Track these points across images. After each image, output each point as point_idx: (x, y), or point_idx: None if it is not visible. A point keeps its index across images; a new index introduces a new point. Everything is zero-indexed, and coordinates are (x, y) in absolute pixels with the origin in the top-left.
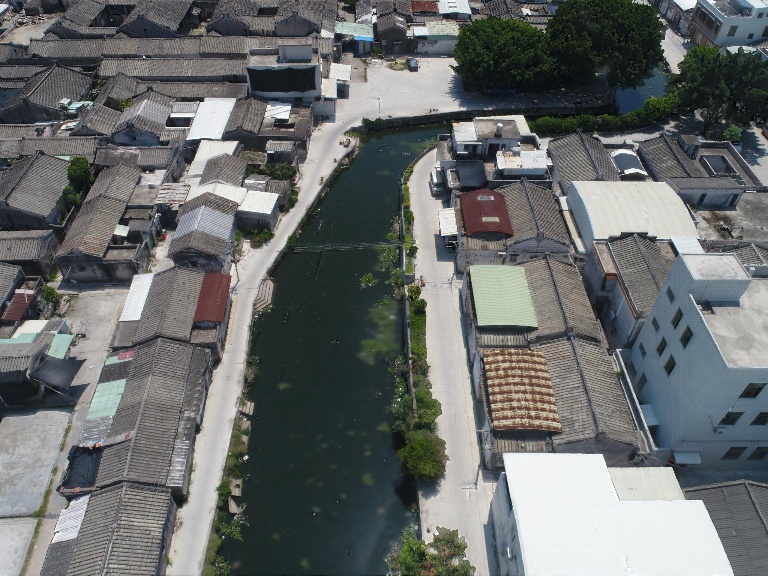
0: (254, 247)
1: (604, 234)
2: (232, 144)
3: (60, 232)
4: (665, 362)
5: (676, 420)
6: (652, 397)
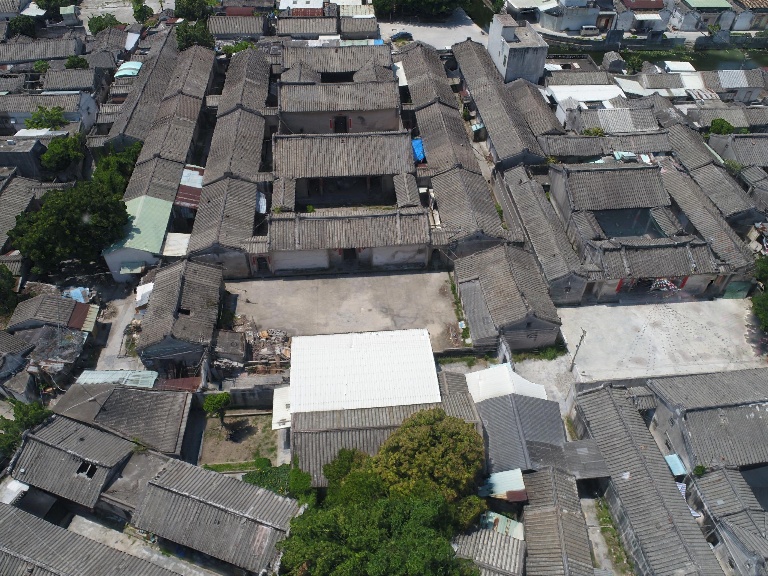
0: None
1: None
2: (619, 80)
3: None
4: None
5: None
6: None
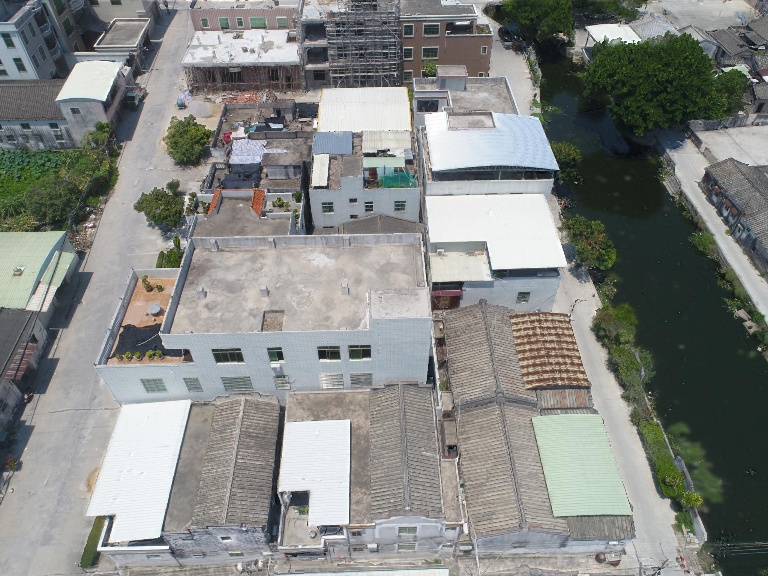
0: None
1: None
2: None
3: None
4: None
5: None
6: None
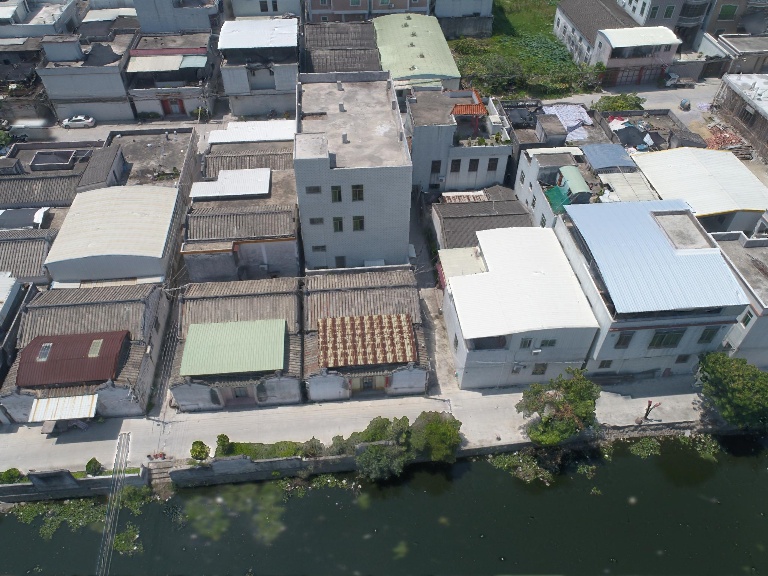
0: None
1: (156, 249)
2: None
3: None
4: (352, 227)
5: (397, 239)
6: (361, 257)
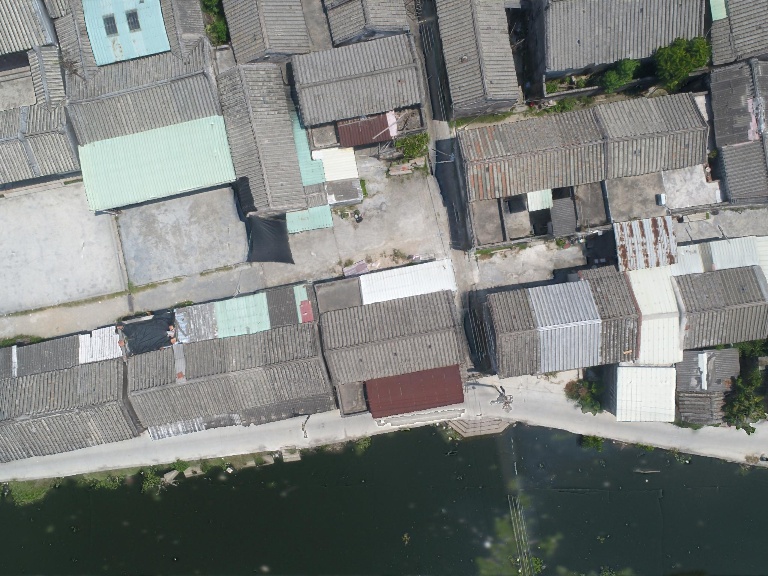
0: (568, 389)
1: None
2: None
3: (540, 93)
4: None
5: None
6: None
